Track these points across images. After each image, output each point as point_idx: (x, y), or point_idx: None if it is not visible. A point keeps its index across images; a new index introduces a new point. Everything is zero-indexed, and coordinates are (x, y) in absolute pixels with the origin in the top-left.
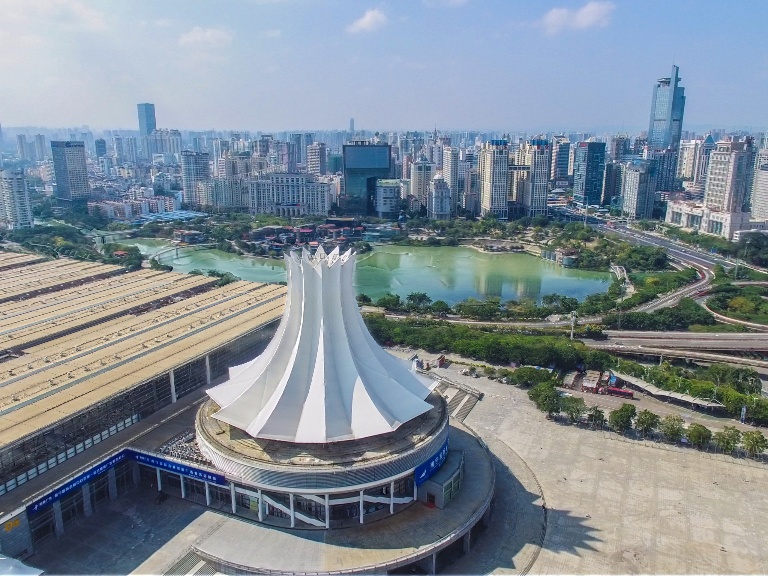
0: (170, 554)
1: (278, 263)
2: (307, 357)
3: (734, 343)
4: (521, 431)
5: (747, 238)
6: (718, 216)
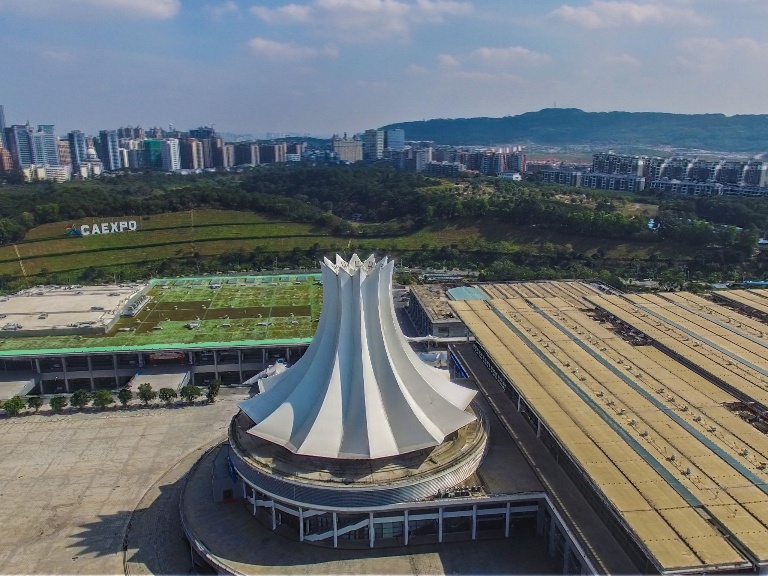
0: None
1: None
2: None
3: None
4: None
5: None
6: None
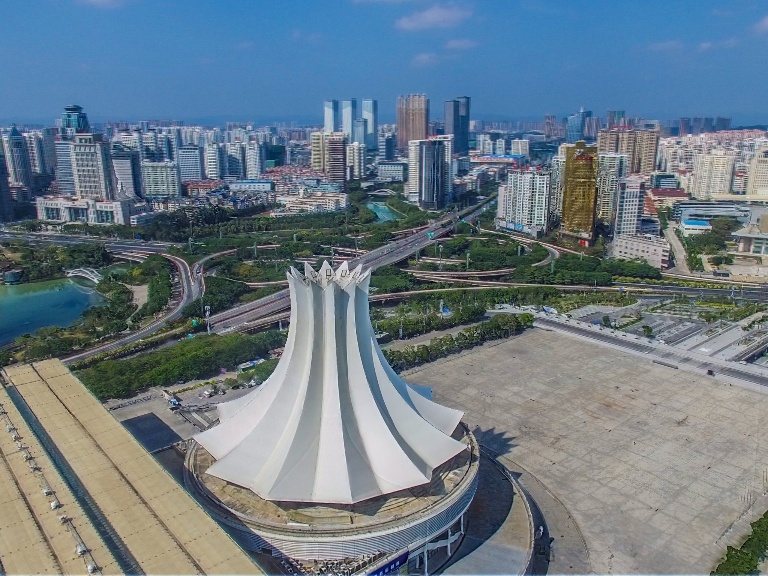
0: None
1: None
2: None
3: None
4: None
5: (157, 221)
6: (106, 205)
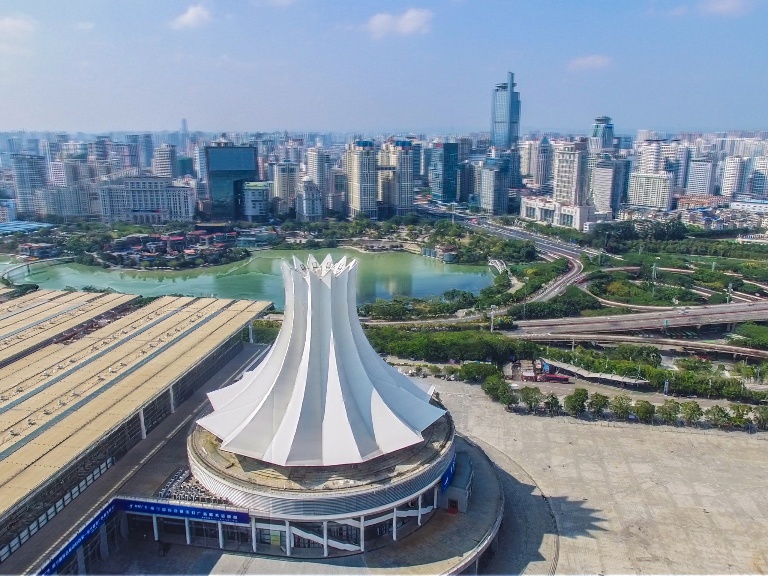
0: None
1: (151, 274)
2: (317, 374)
3: (625, 324)
4: (489, 425)
5: (598, 229)
6: (568, 210)
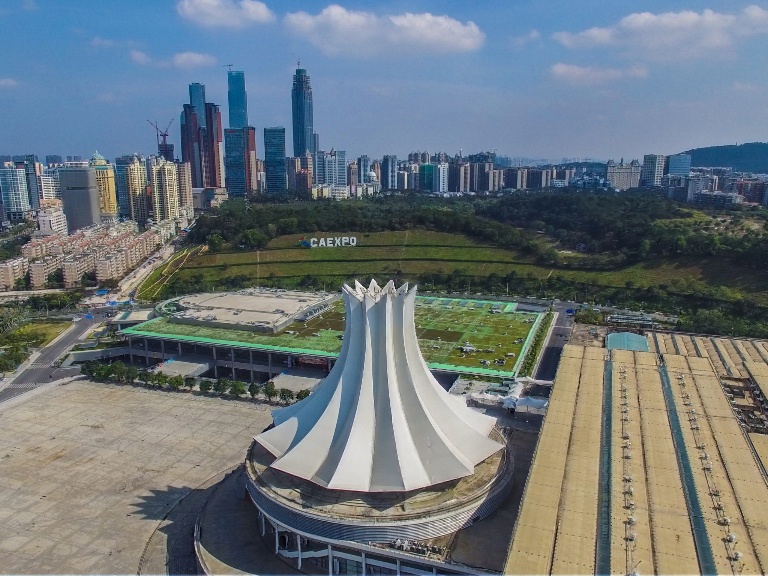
0: None
1: None
2: None
3: None
4: None
5: None
6: None
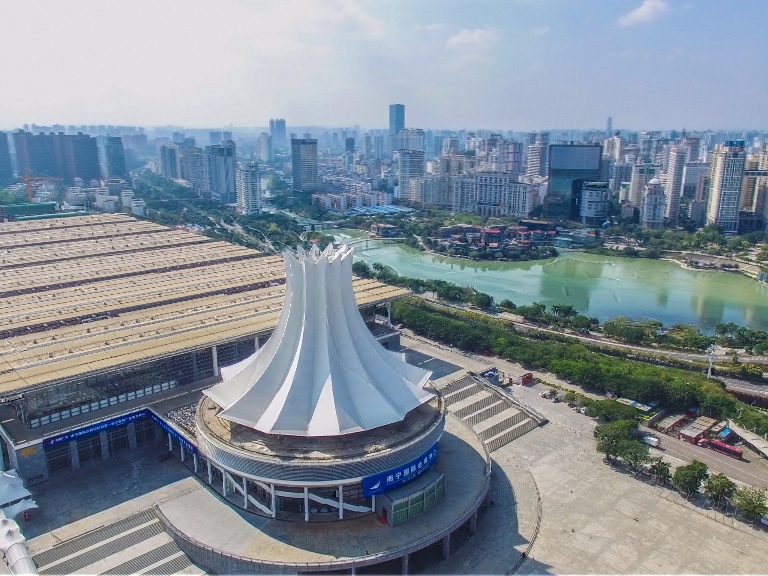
0: (136, 506)
1: (456, 262)
2: (290, 349)
3: None
4: (562, 468)
5: None
6: None
